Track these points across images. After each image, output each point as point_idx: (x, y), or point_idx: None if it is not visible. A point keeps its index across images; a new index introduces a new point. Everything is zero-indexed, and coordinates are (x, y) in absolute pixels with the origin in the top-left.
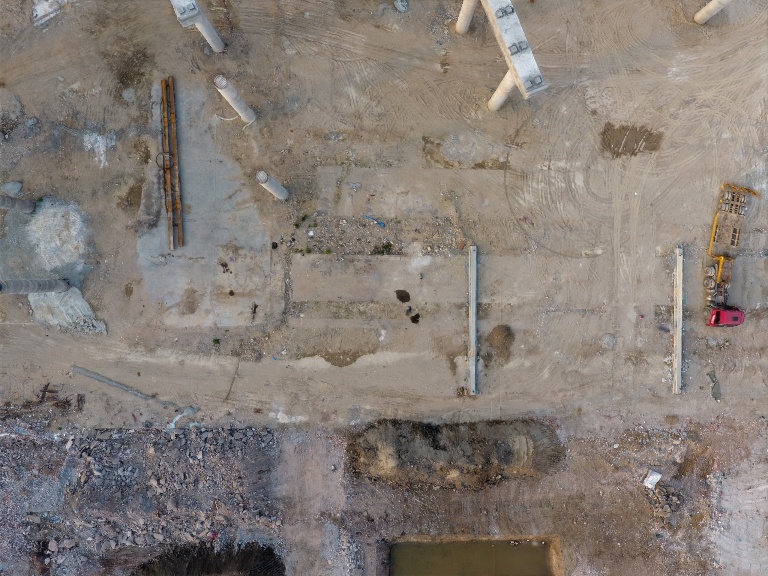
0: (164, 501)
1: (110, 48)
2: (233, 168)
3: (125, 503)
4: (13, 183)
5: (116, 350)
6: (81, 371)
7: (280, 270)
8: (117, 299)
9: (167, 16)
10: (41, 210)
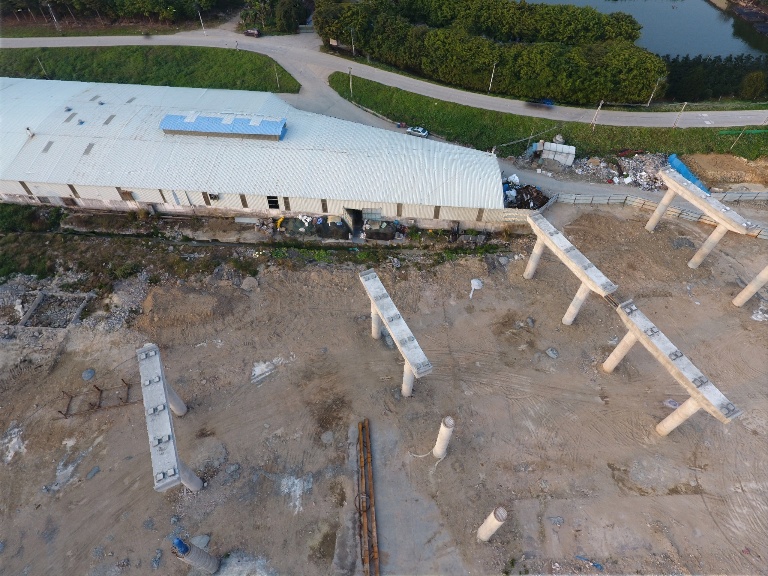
0: None
1: (313, 397)
2: (430, 507)
3: None
4: (201, 537)
5: None
6: None
7: None
8: None
9: (363, 370)
10: (226, 569)
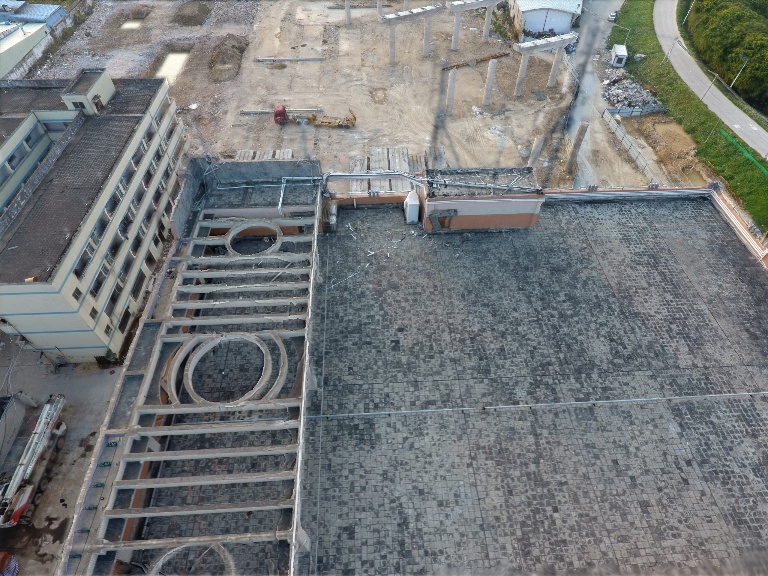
0: (231, 3)
1: None
2: None
3: None
4: None
5: (290, 0)
6: None
7: None
8: (309, 0)
9: None
10: None
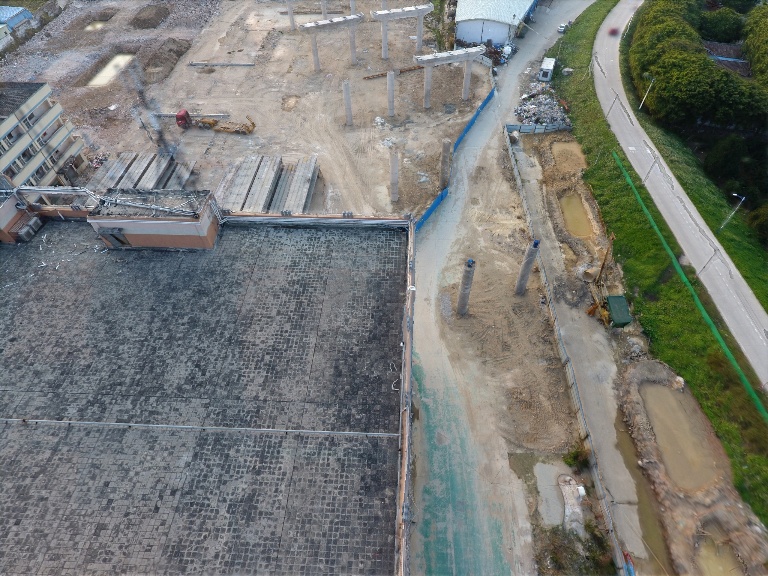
0: (188, 7)
1: None
2: None
3: (192, 3)
4: None
5: (248, 5)
6: (244, 0)
7: (263, 29)
8: (266, 5)
9: None
10: None
